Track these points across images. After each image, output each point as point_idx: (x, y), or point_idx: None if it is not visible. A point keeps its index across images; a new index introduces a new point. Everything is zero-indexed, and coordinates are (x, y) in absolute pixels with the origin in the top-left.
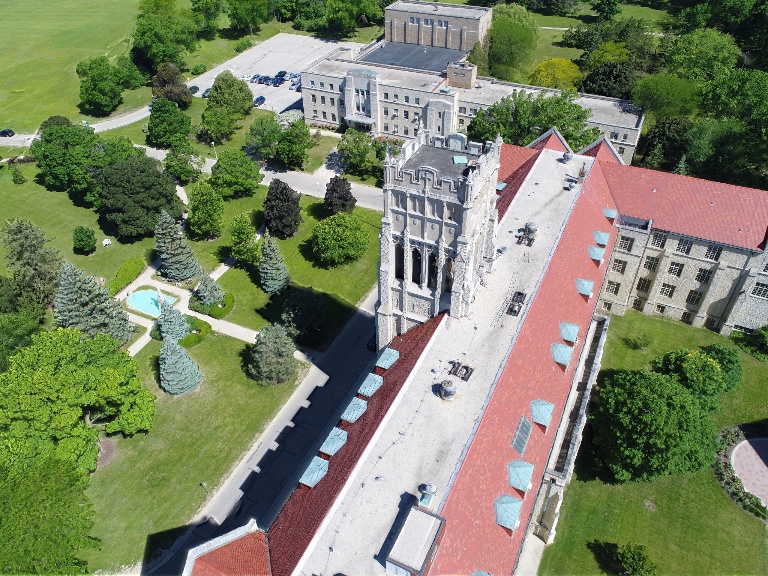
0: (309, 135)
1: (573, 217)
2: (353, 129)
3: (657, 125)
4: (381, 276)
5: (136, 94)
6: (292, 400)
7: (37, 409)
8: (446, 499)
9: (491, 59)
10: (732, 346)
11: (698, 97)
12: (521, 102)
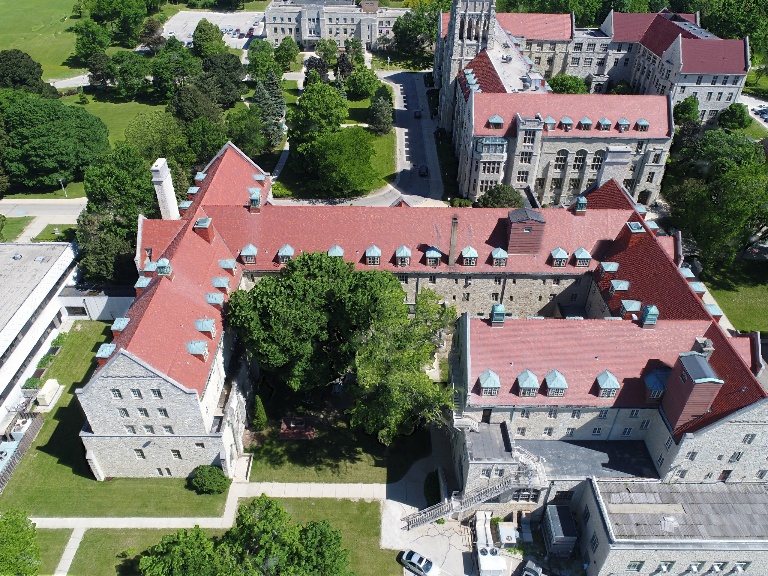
0: None
1: None
2: None
3: None
4: (455, 37)
5: (110, 52)
6: (398, 137)
7: (333, 108)
8: None
9: None
10: None
11: (505, 0)
12: (425, 6)
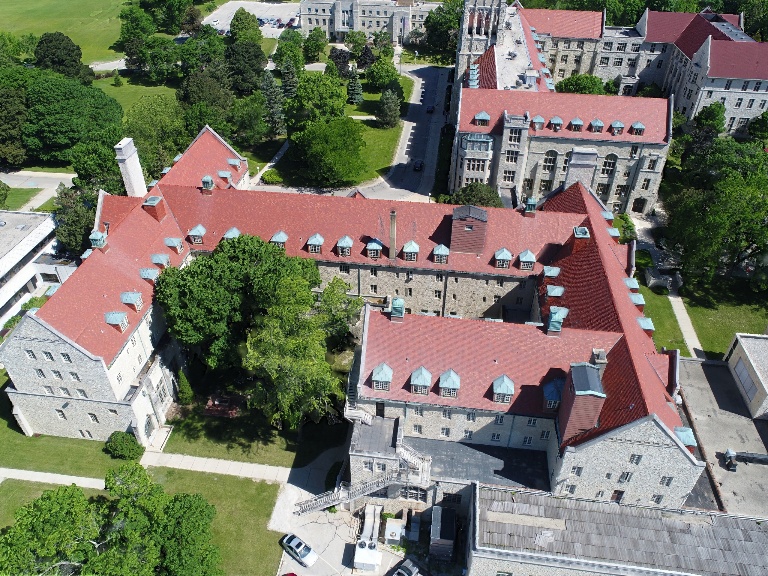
0: (325, 36)
1: (522, 22)
2: None
3: None
4: (463, 31)
5: None
6: (404, 131)
7: None
8: None
9: None
10: None
11: None
12: (457, 0)
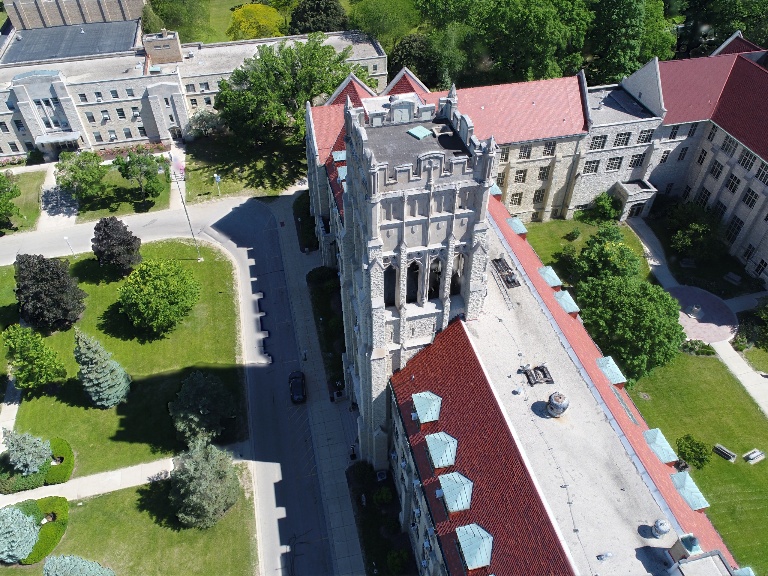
0: (7, 180)
1: None
2: (68, 152)
3: (396, 48)
4: (374, 315)
5: None
6: (260, 520)
7: None
8: (679, 526)
9: (166, 23)
10: (581, 225)
11: (417, 11)
12: (271, 58)
